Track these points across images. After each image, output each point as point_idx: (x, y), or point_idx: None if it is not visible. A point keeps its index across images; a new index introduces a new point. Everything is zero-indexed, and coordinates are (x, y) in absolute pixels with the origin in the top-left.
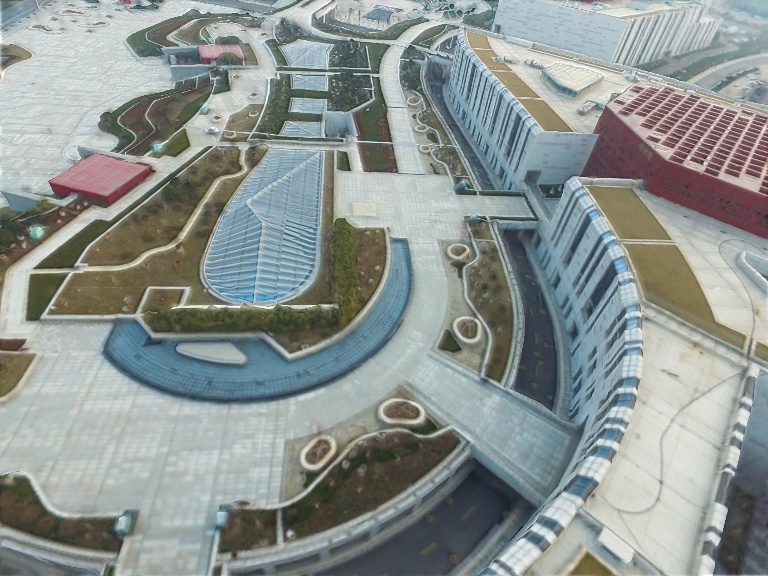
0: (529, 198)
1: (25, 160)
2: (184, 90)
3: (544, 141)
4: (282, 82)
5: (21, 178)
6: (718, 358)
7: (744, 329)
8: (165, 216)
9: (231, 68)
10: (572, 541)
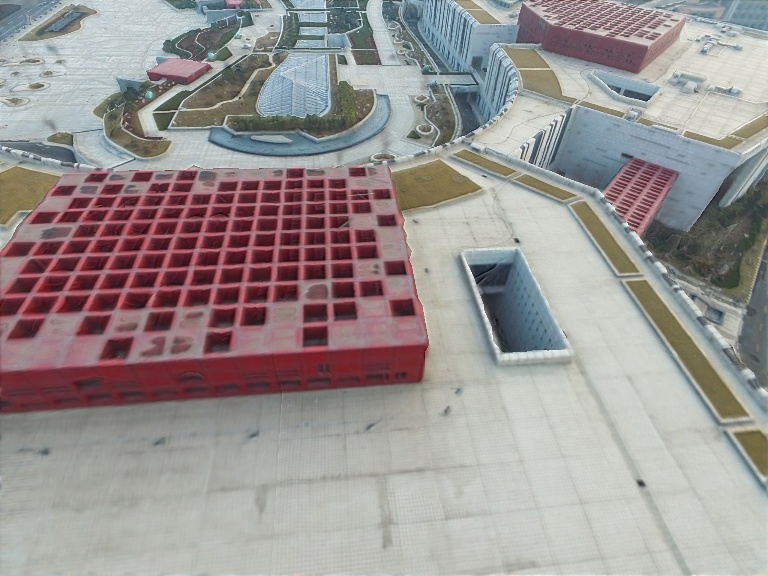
0: (474, 75)
1: (119, 70)
2: (219, 26)
3: (481, 32)
4: (292, 18)
5: None
6: (557, 106)
7: (578, 98)
8: (227, 87)
9: (252, 11)
10: (459, 149)
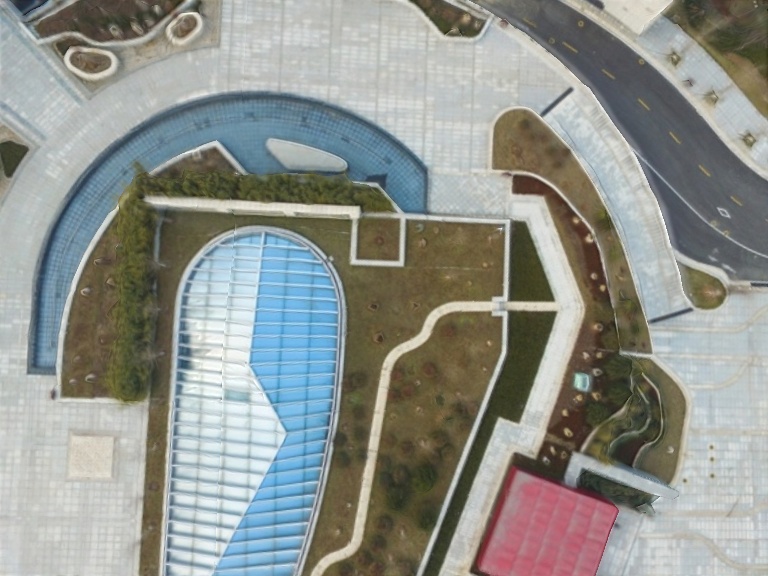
0: None
1: None
2: None
3: None
4: None
5: (683, 570)
6: None
7: None
8: (420, 426)
9: None
10: None
